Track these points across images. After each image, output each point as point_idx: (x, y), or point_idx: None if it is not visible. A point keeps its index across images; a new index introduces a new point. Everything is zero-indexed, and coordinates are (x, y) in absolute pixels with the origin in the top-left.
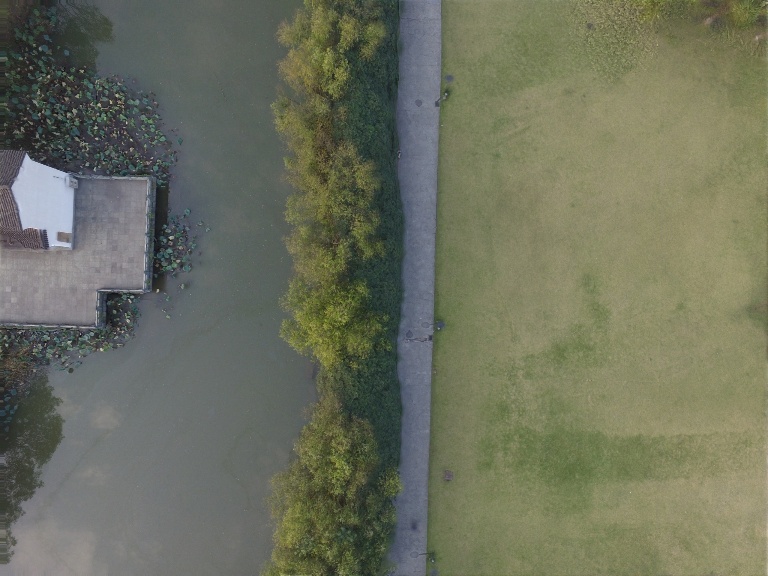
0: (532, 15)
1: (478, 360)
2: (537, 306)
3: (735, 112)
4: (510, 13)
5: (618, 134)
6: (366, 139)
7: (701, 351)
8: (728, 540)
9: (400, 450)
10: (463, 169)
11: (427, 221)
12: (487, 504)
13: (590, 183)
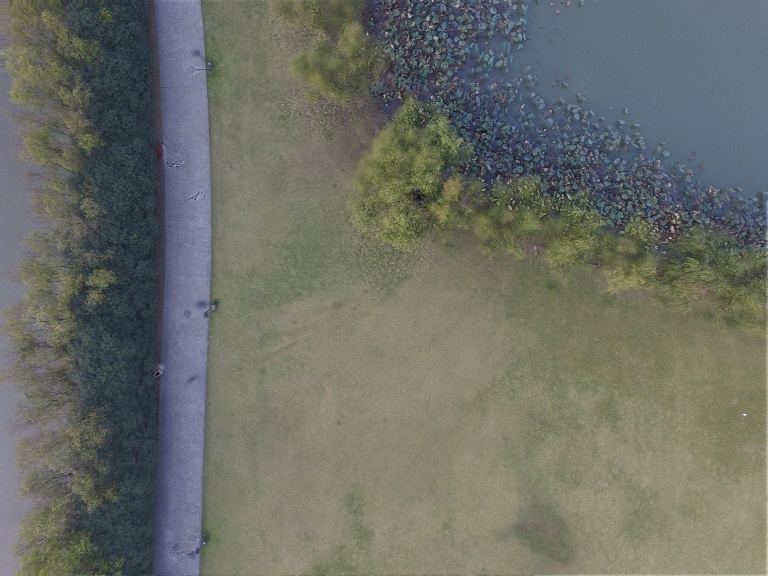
0: (303, 225)
1: None
2: (298, 527)
3: (511, 324)
4: (280, 224)
5: (388, 349)
6: (99, 382)
7: (466, 570)
8: None
9: None
10: (229, 384)
11: (195, 433)
12: None
13: (357, 400)
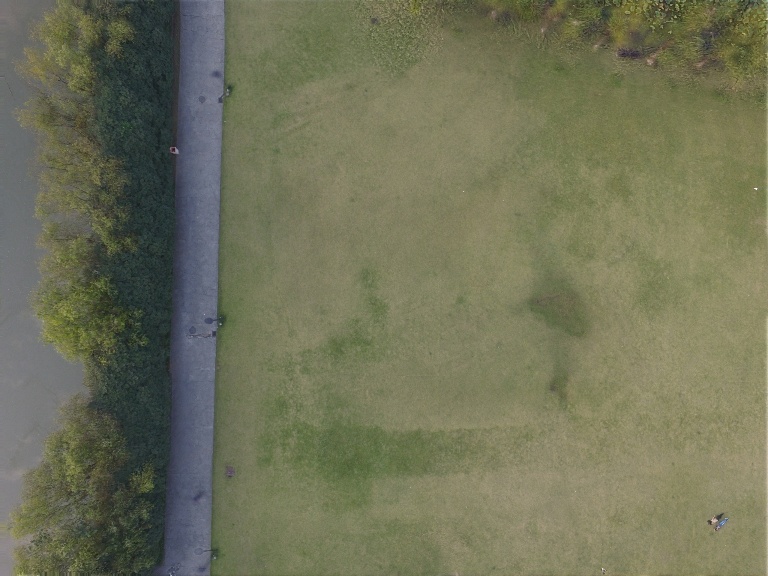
0: (314, 11)
1: (257, 355)
2: (314, 301)
3: (520, 105)
4: (292, 9)
5: (399, 128)
6: (118, 135)
7: (482, 345)
8: (510, 535)
9: (173, 446)
10: (244, 165)
11: (211, 217)
12: (268, 500)
13: (370, 177)
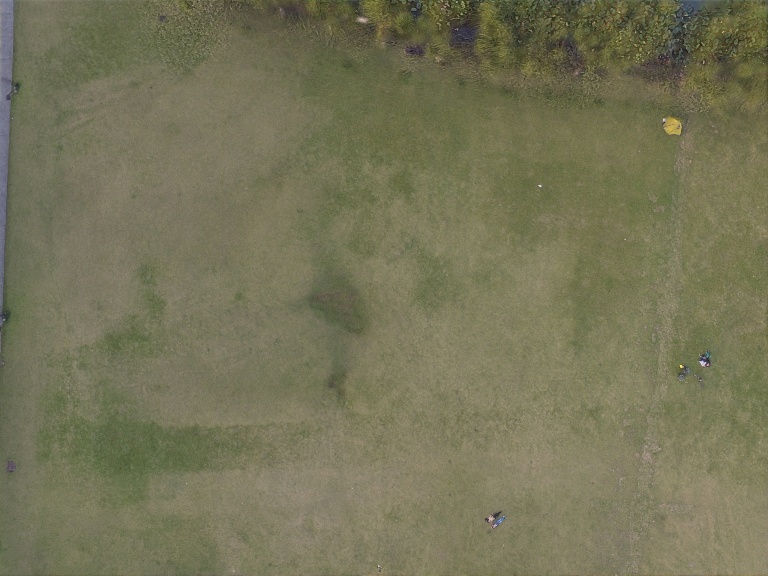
0: (101, 8)
1: (37, 351)
2: (92, 297)
3: (306, 102)
4: (78, 7)
5: (183, 125)
6: None
7: (260, 341)
8: (286, 532)
9: None
10: (28, 161)
11: None
12: (47, 495)
13: (151, 174)
